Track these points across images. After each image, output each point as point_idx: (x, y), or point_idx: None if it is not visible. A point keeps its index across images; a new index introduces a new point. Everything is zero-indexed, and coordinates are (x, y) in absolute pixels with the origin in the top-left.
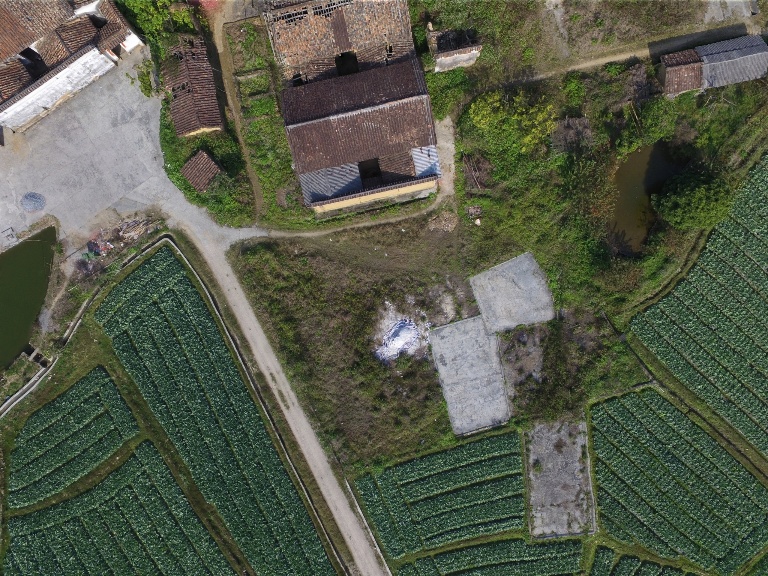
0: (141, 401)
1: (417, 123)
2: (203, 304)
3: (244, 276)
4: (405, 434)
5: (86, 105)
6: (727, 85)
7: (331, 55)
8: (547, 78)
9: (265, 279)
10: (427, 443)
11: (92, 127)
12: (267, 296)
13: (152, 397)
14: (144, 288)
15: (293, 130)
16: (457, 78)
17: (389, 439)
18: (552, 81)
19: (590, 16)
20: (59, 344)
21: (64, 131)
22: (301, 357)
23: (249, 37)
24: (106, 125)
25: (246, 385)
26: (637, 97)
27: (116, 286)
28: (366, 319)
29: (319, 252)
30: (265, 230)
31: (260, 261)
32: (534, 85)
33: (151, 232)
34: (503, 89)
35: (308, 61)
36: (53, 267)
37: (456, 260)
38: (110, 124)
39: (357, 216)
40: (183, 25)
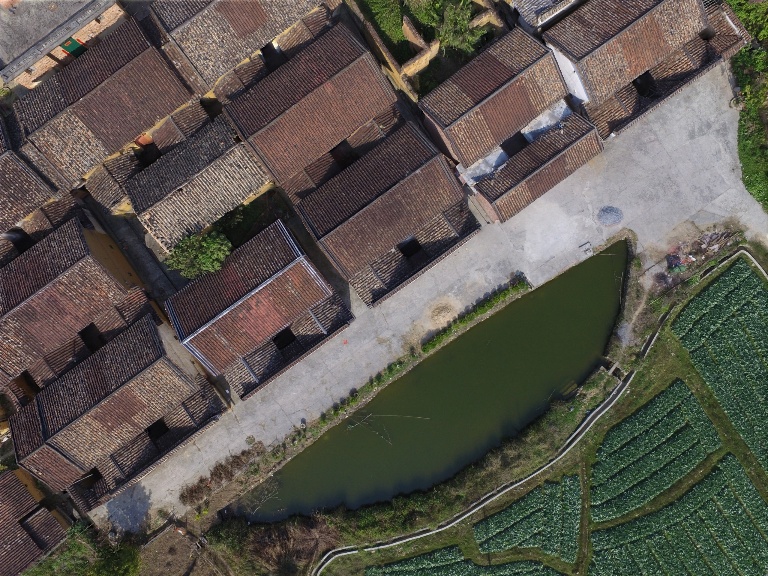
0: (721, 414)
1: None
2: None
3: None
4: None
5: (663, 118)
6: None
7: None
8: None
9: None
10: None
11: (669, 140)
12: None
13: (735, 410)
14: (725, 301)
15: None
16: None
17: None
18: None
19: None
20: (643, 358)
21: (640, 144)
22: None
23: None
24: (683, 137)
25: None
26: None
27: (694, 299)
28: None
29: None
30: None
31: None
32: None
33: (731, 244)
34: None
35: None
36: (631, 281)
37: None
38: (687, 136)
39: None
40: None
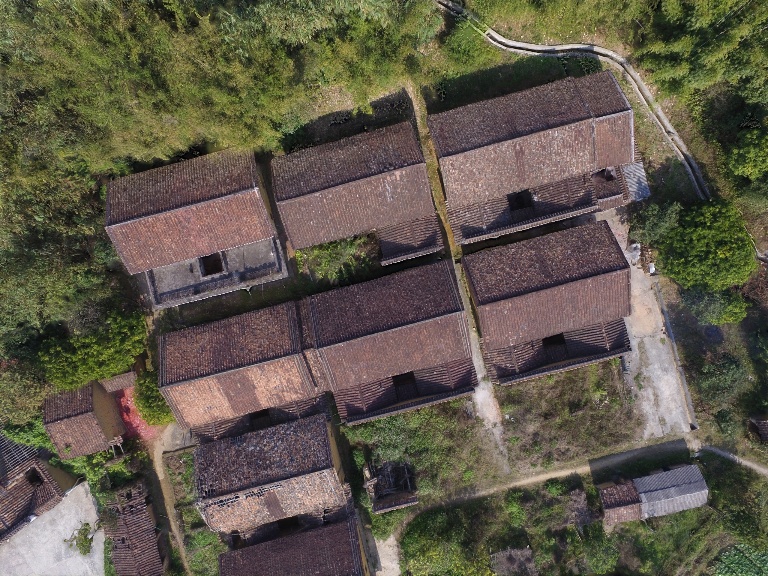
0: None
1: None
2: None
3: None
4: None
5: (30, 541)
6: (668, 514)
7: (267, 522)
8: (489, 495)
9: None
10: None
11: (37, 562)
12: None
13: None
14: None
15: None
16: None
17: None
18: (494, 499)
19: (528, 439)
20: None
21: (9, 567)
22: None
23: (189, 469)
24: (51, 560)
25: None
26: (579, 522)
27: None
28: None
29: None
30: None
31: None
32: (476, 506)
33: None
34: (445, 514)
35: None
36: None
37: None
38: (54, 559)
39: None
40: (121, 472)
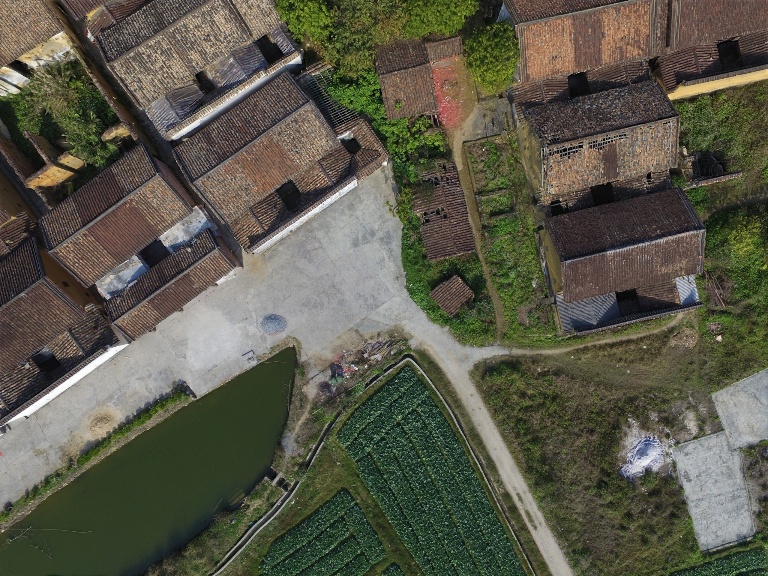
0: (386, 524)
1: (688, 254)
2: (448, 425)
3: (492, 397)
4: (651, 551)
5: (327, 225)
6: None
7: (597, 184)
8: None
9: (510, 399)
10: (674, 560)
11: (333, 247)
12: (513, 416)
13: (398, 520)
14: (389, 410)
15: (569, 264)
16: (699, 196)
17: (636, 557)
18: None
19: None
20: (304, 469)
21: (304, 251)
22: (549, 477)
23: (492, 156)
24: (347, 245)
25: (492, 506)
26: None
27: (359, 408)
28: (612, 437)
29: (561, 369)
30: (506, 348)
31: (505, 381)
32: None
33: (394, 353)
34: (745, 207)
35: (573, 190)
36: (295, 390)
37: (698, 376)
38: (351, 244)
39: (599, 333)
40: (433, 148)
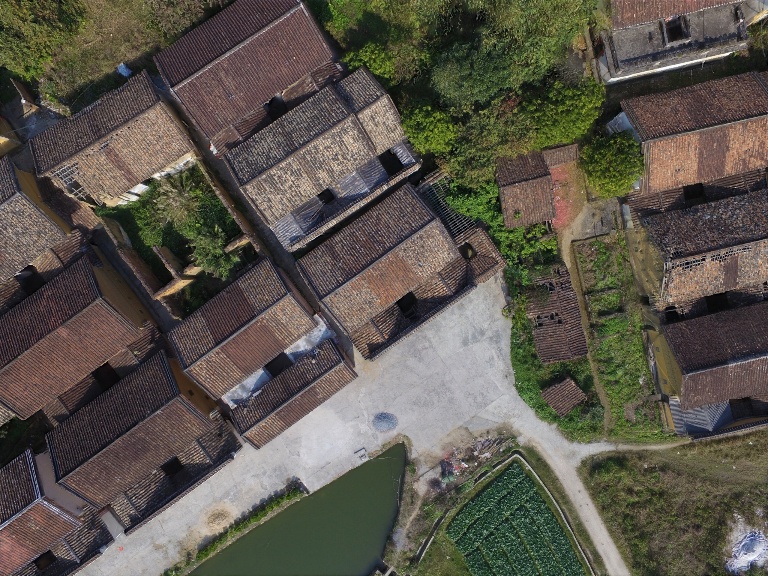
0: None
1: None
2: (556, 520)
3: (600, 495)
4: None
5: (437, 325)
6: None
7: (715, 293)
8: None
9: (618, 495)
10: None
11: (443, 347)
12: (620, 512)
13: None
14: (498, 506)
15: (690, 376)
16: None
17: None
18: None
19: None
20: (416, 564)
21: (415, 351)
22: (656, 573)
23: (601, 256)
24: (457, 344)
25: None
26: None
27: (468, 503)
28: (718, 533)
29: (667, 465)
30: (613, 444)
31: (613, 478)
32: None
33: (503, 450)
34: None
35: None
36: (406, 486)
37: None
38: (461, 343)
39: None
40: (545, 251)
